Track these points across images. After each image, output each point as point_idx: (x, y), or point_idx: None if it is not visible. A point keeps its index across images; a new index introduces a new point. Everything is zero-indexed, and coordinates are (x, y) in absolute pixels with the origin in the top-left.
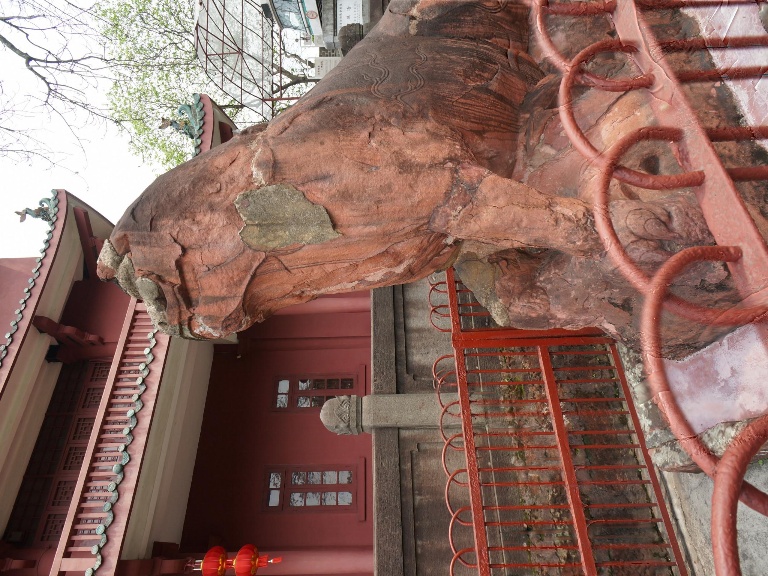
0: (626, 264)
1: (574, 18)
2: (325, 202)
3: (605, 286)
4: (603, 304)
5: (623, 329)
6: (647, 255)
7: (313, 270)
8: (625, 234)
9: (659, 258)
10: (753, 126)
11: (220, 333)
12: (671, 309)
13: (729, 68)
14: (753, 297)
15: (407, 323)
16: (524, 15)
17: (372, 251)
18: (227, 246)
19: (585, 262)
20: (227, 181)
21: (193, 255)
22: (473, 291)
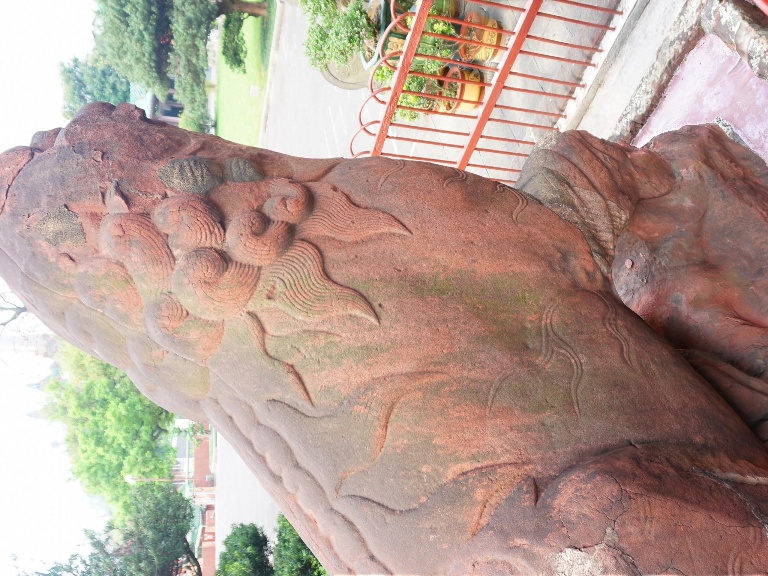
0: None
1: None
2: None
3: None
4: None
5: None
6: None
7: None
8: None
9: None
10: None
11: None
12: None
13: None
14: None
15: None
16: None
17: None
18: None
19: None
20: None
21: None
22: None
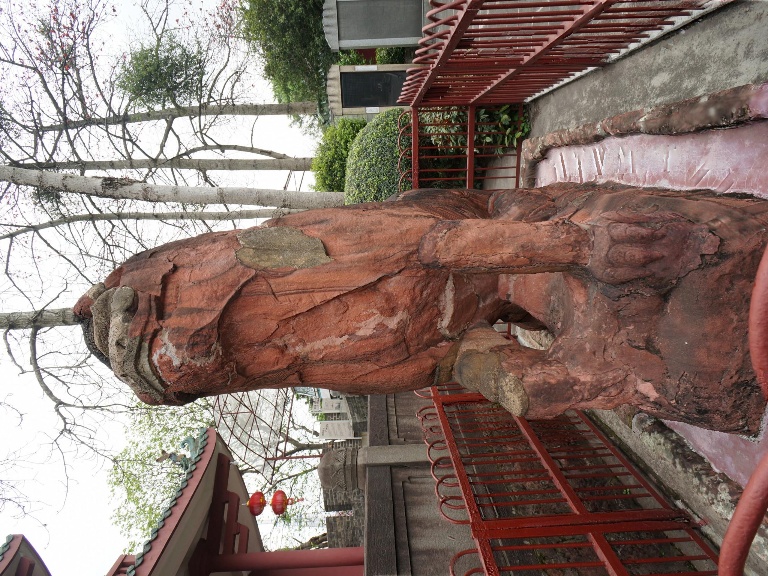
0: (616, 244)
1: (521, 197)
2: (320, 236)
3: (617, 323)
4: (625, 349)
5: (664, 390)
6: (631, 229)
7: (301, 299)
8: (603, 221)
9: (644, 231)
10: (681, 188)
11: (183, 356)
12: (694, 315)
13: (645, 180)
14: (764, 267)
15: (412, 543)
16: (484, 208)
17: (363, 279)
18: (219, 263)
19: (587, 308)
20: (234, 232)
21: (183, 273)
22: (480, 384)
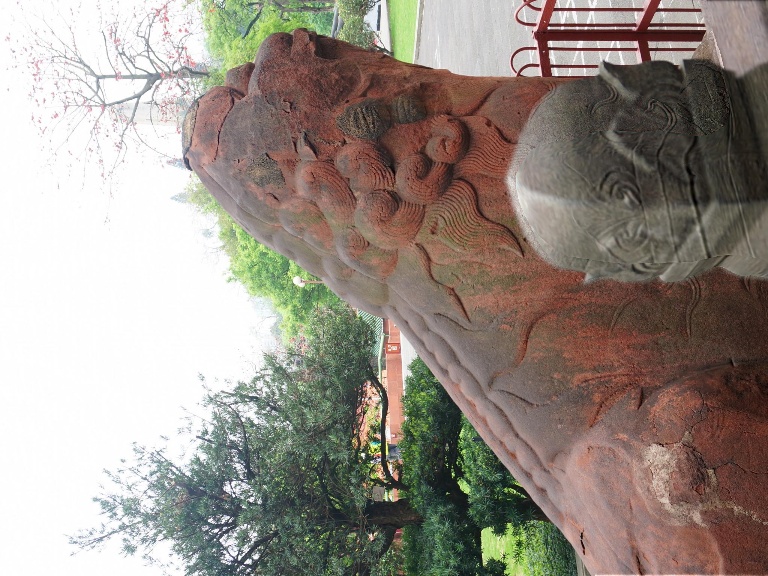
0: None
1: None
2: None
3: None
4: None
5: None
6: None
7: None
8: None
9: None
10: None
11: None
12: None
13: None
14: None
15: None
16: None
17: None
18: None
19: None
20: None
21: None
22: None
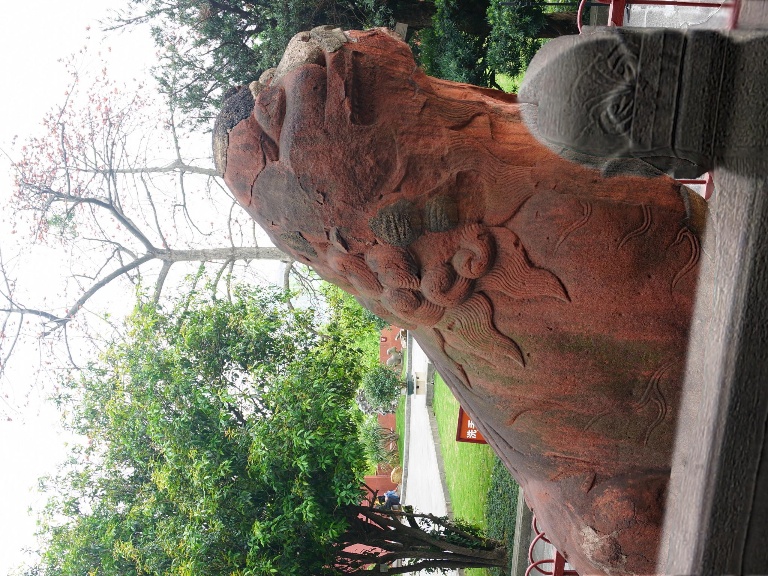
0: None
1: None
2: None
3: None
4: None
5: None
6: None
7: None
8: None
9: None
10: None
11: (378, 29)
12: None
13: None
14: None
15: None
16: None
17: None
18: None
19: None
20: None
21: None
22: None
